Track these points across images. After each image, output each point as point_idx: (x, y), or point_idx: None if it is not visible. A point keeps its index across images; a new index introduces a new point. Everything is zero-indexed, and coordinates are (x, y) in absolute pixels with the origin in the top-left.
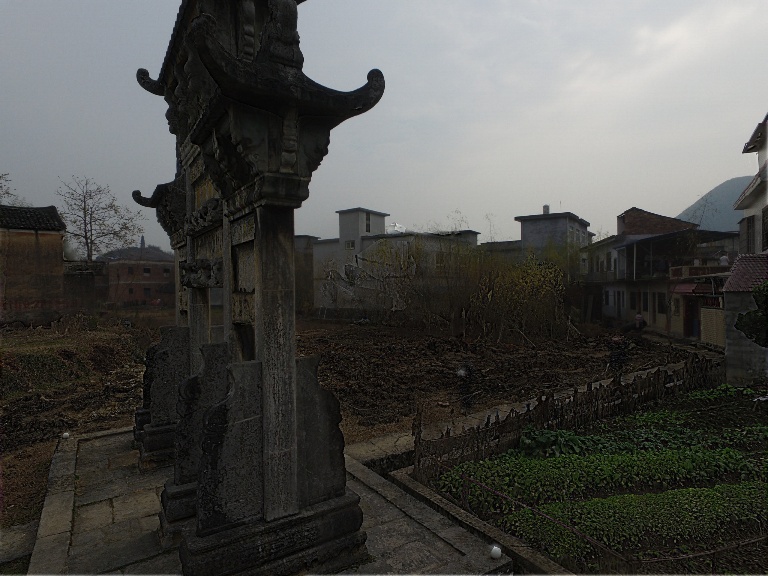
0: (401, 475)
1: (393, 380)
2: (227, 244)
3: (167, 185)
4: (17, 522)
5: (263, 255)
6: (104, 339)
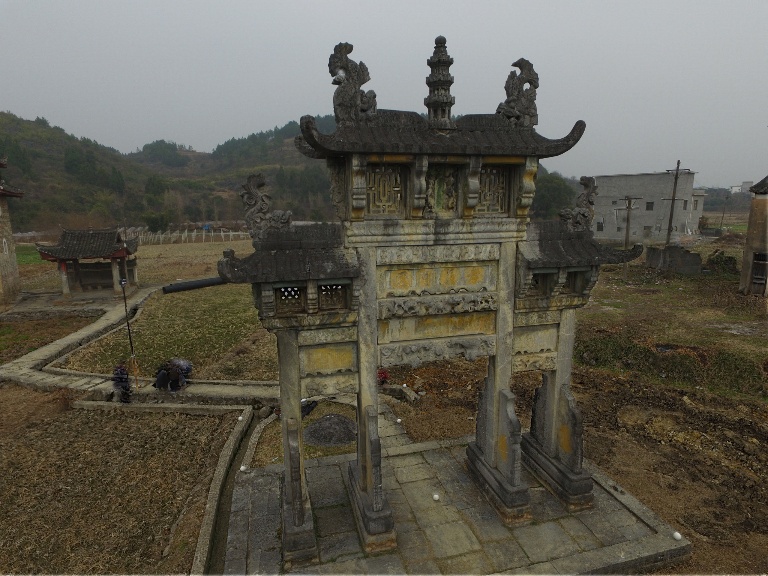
0: None
1: None
2: None
3: None
4: None
5: None
6: None
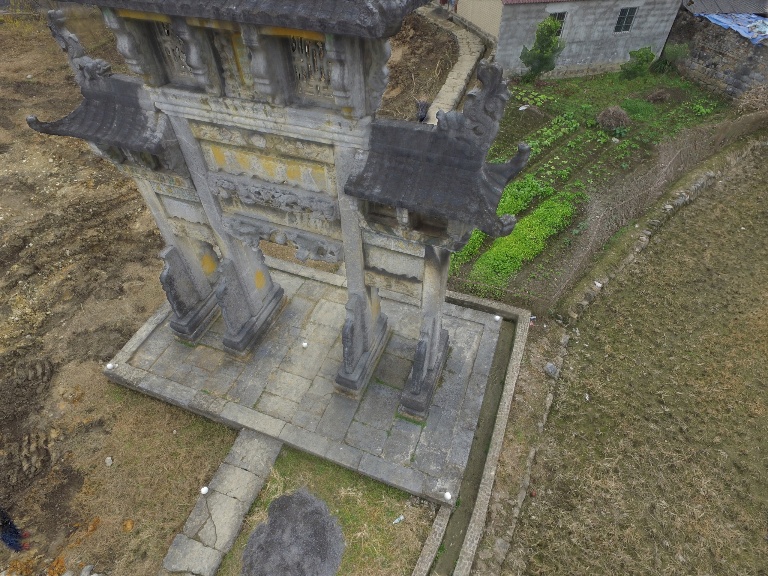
0: None
1: None
2: (357, 242)
3: (160, 143)
4: (204, 436)
5: (443, 273)
6: None
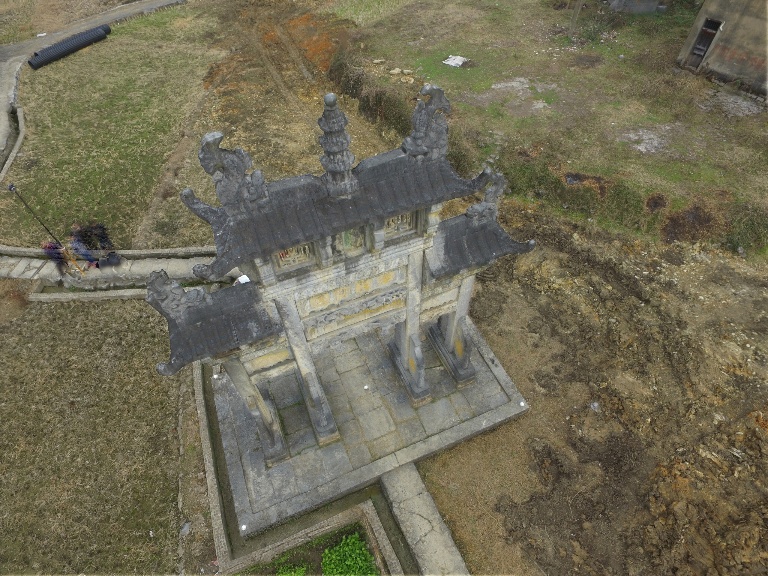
0: (364, 508)
1: (685, 570)
2: None
3: None
4: None
5: None
6: (735, 198)
